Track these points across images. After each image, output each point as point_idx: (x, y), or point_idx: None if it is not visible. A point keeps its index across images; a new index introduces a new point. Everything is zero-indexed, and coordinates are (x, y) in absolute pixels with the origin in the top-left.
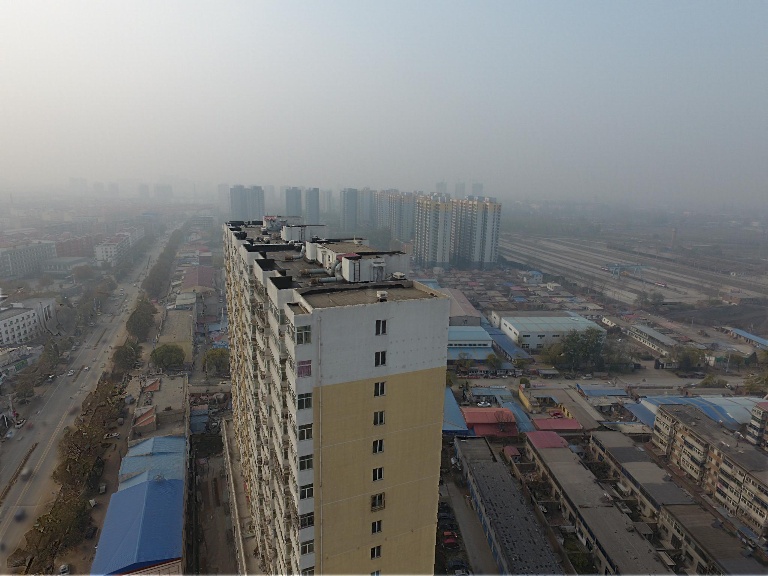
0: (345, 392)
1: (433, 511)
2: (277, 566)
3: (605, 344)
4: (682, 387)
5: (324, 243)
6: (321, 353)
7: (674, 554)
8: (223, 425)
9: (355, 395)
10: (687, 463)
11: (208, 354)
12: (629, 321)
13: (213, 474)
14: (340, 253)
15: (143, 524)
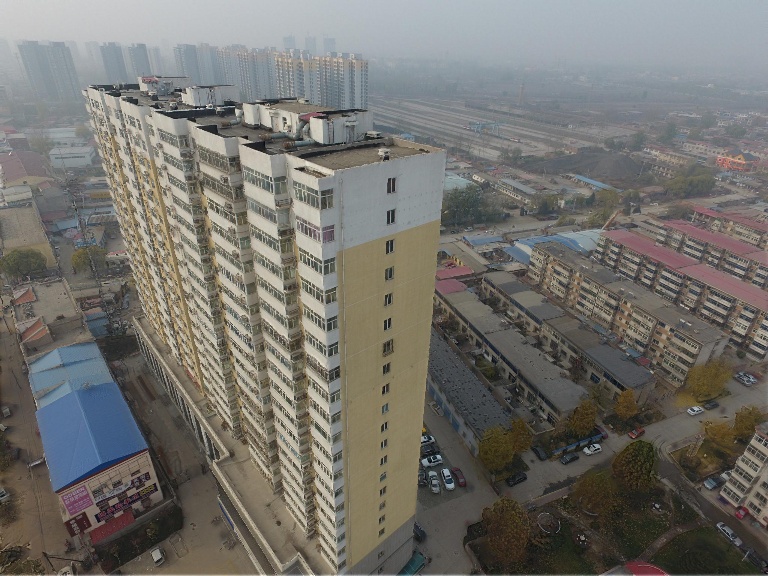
0: (363, 253)
1: (426, 348)
2: (276, 426)
3: (482, 198)
4: (544, 228)
5: (267, 104)
6: (343, 216)
7: (553, 354)
8: (135, 323)
9: (371, 255)
10: (556, 287)
11: (78, 254)
12: (495, 176)
13: (135, 373)
14: (302, 113)
15: (91, 430)
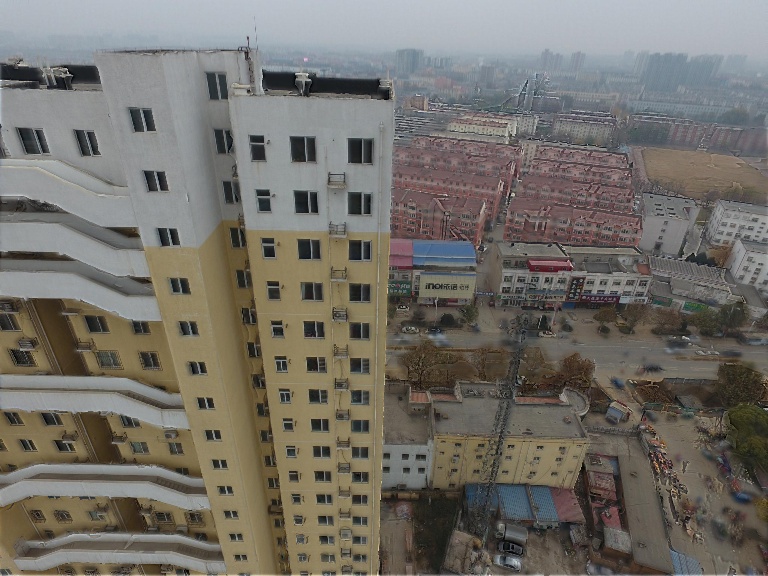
0: None
1: None
2: None
3: None
4: None
5: None
6: None
7: None
8: None
9: None
10: None
11: None
12: None
13: None
14: None
15: None
